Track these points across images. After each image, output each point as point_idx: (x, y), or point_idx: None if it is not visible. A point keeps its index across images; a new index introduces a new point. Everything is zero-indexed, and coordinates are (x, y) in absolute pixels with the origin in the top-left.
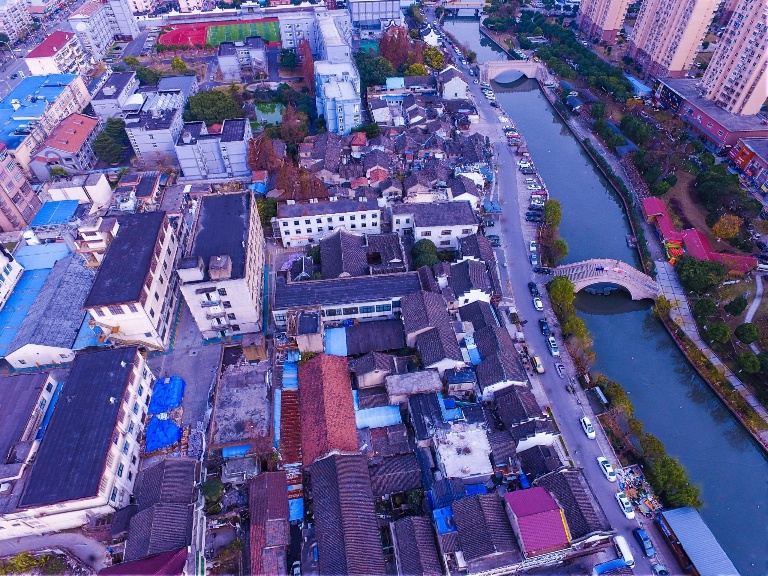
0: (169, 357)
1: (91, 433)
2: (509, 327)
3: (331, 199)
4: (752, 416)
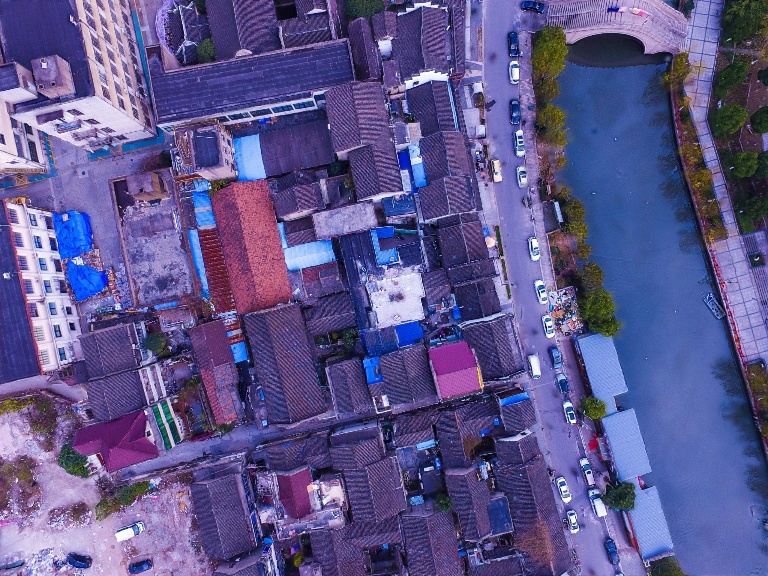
0: (56, 181)
1: (4, 313)
2: (470, 114)
3: None
4: (716, 225)
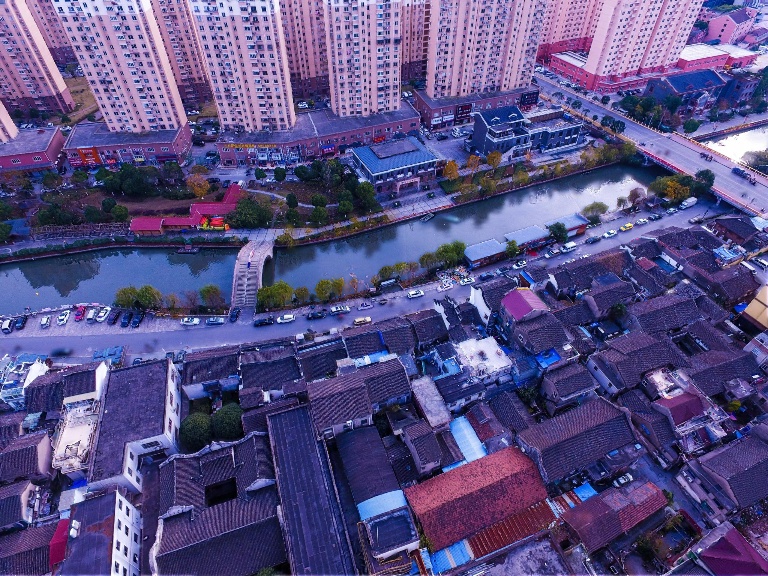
0: None
1: None
2: None
3: None
4: (380, 220)
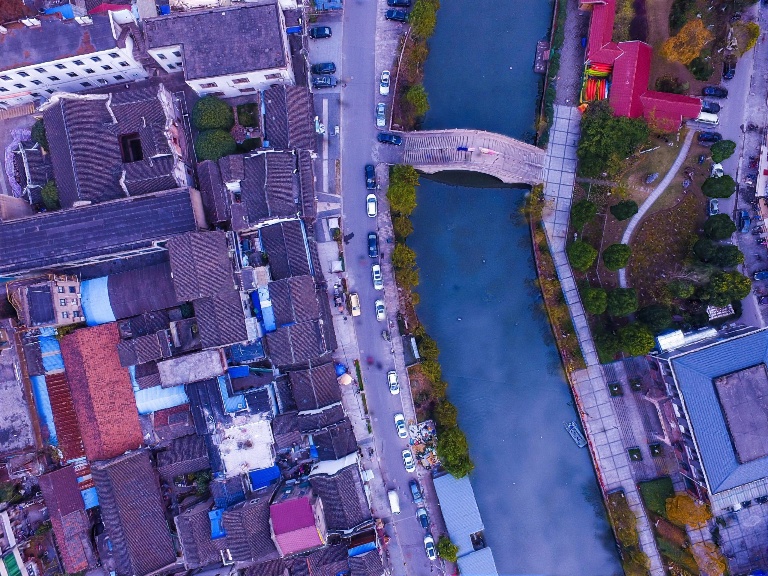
0: None
1: None
2: (328, 247)
3: (27, 23)
4: (575, 355)
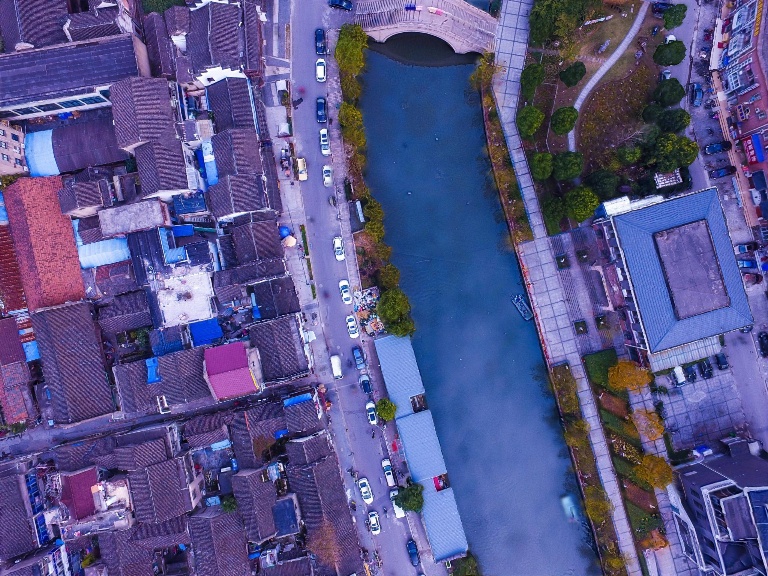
0: None
1: None
2: (277, 111)
3: None
4: (523, 226)
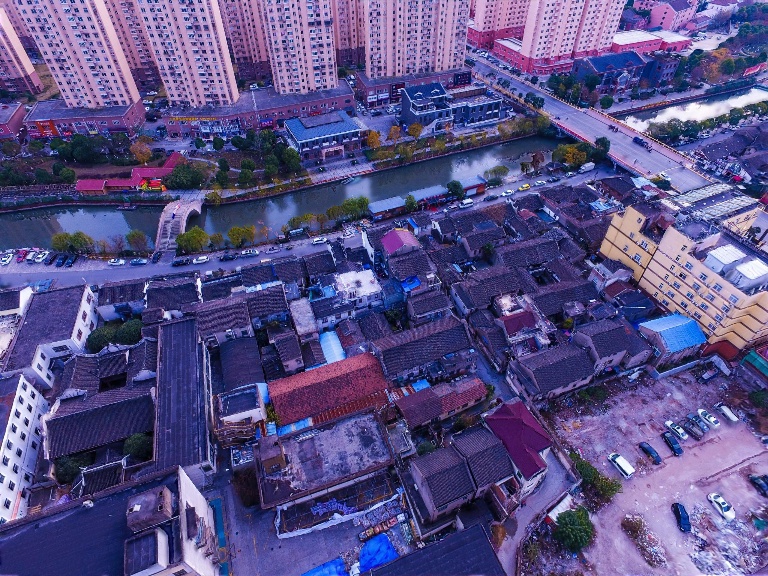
0: None
1: None
2: None
3: None
4: (303, 182)
